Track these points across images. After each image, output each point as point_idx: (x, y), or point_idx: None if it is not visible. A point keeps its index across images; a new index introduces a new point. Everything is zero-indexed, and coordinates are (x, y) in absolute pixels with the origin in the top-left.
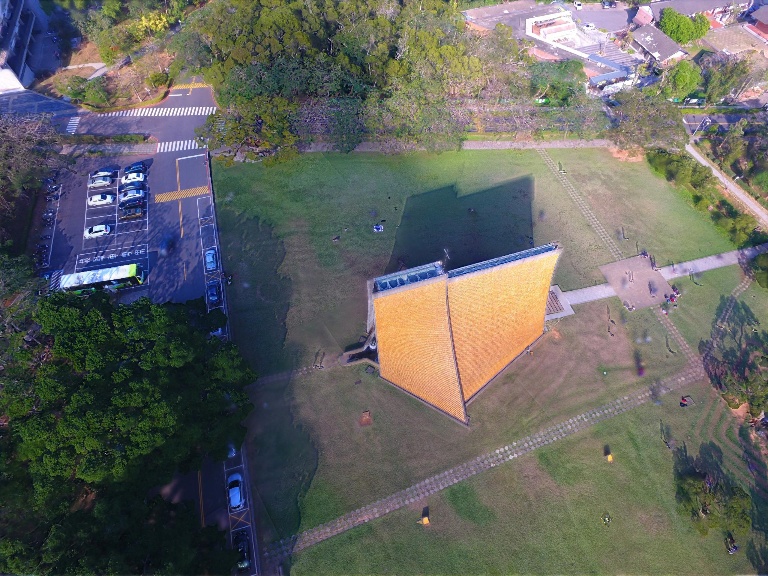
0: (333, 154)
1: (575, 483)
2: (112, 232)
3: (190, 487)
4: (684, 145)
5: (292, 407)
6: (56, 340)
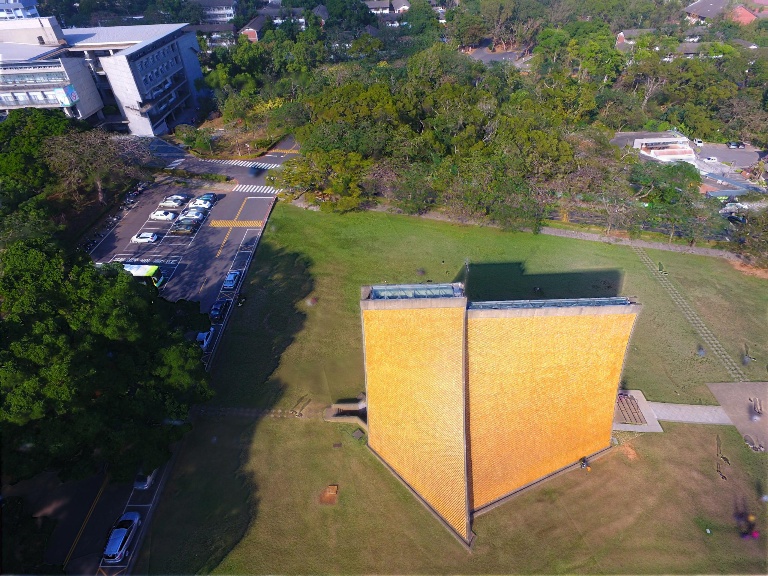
0: (397, 216)
1: None
2: (157, 241)
3: (77, 513)
4: None
5: (244, 452)
6: (4, 275)
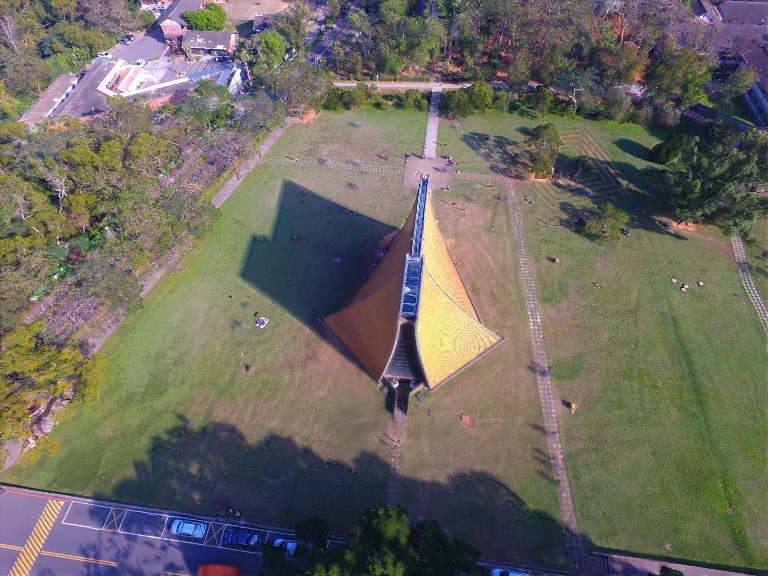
0: None
1: (569, 290)
2: None
3: None
4: (331, 82)
5: (432, 488)
6: None
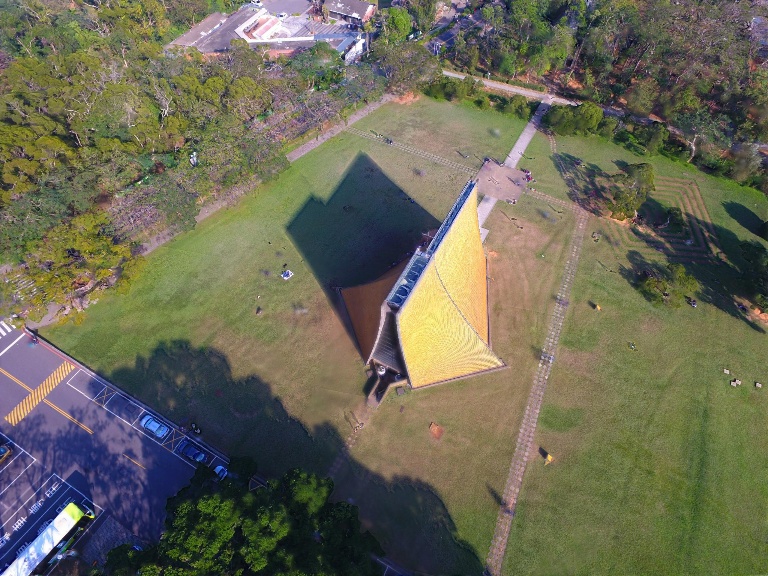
0: None
1: (597, 341)
2: None
3: None
4: (441, 69)
5: (374, 479)
6: None
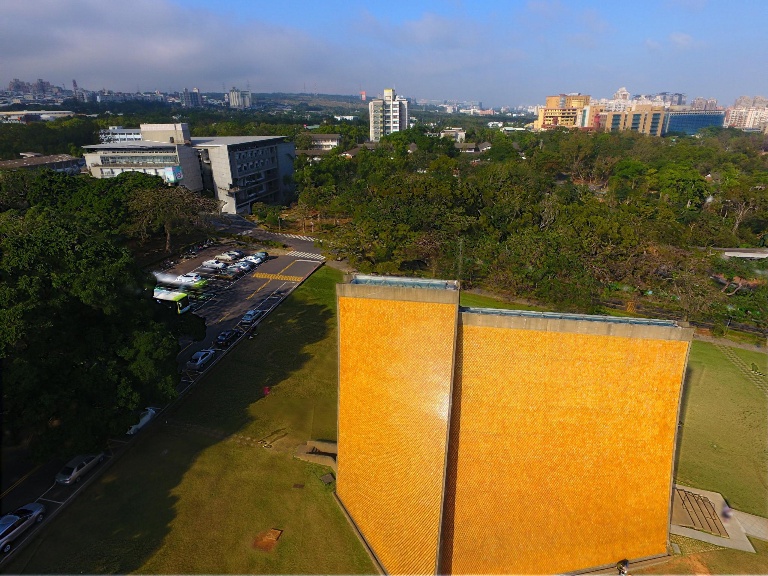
0: None
1: None
2: (199, 282)
3: None
4: None
5: (191, 471)
6: None
